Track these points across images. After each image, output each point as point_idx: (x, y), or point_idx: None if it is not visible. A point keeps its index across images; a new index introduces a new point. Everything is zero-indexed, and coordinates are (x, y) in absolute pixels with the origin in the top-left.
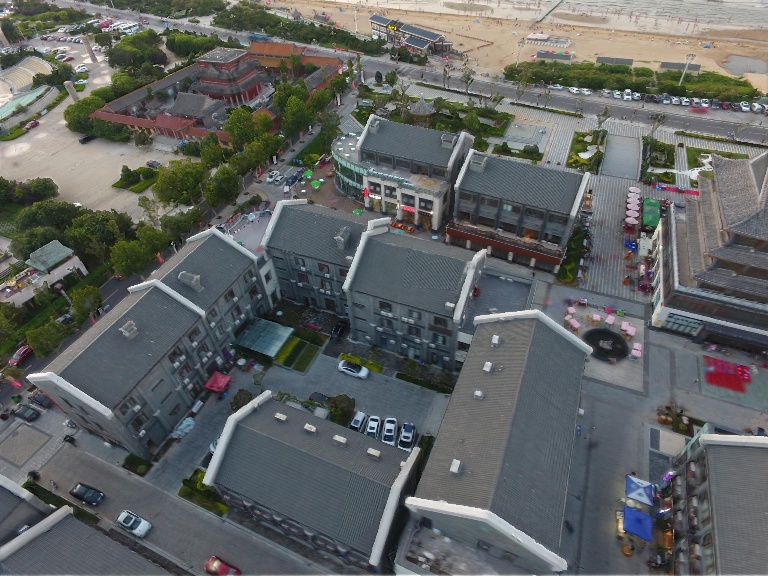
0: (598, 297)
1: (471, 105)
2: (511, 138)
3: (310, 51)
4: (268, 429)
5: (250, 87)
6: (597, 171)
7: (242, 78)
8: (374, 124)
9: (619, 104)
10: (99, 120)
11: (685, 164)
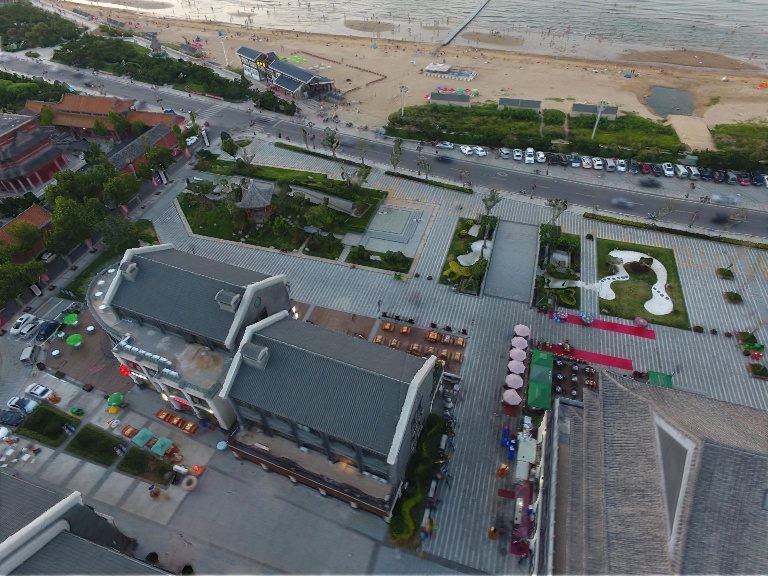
0: (448, 574)
1: (328, 184)
2: (375, 234)
3: (159, 96)
4: None
5: (41, 165)
6: (478, 290)
7: (26, 155)
8: (125, 270)
9: (519, 169)
10: None
11: (594, 270)
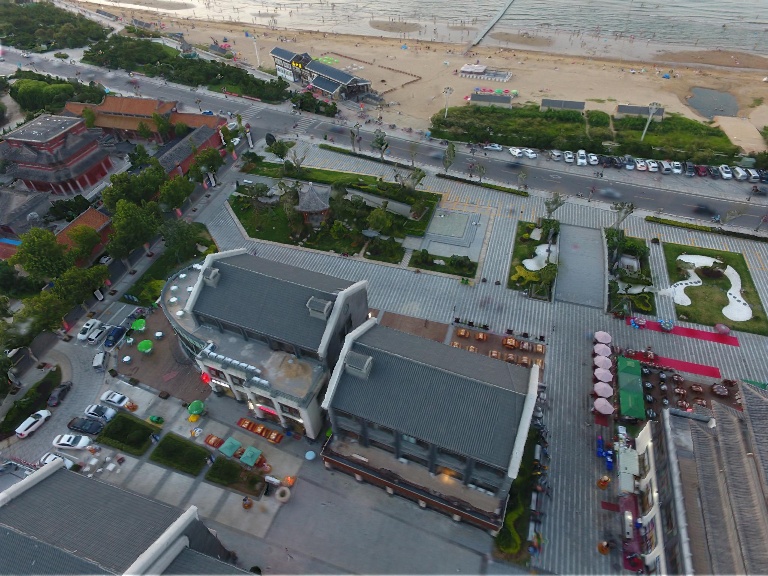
0: None
1: (383, 186)
2: (435, 237)
3: None
4: None
5: (89, 168)
6: (550, 295)
7: (75, 157)
8: (208, 276)
9: (572, 171)
10: None
11: (664, 275)
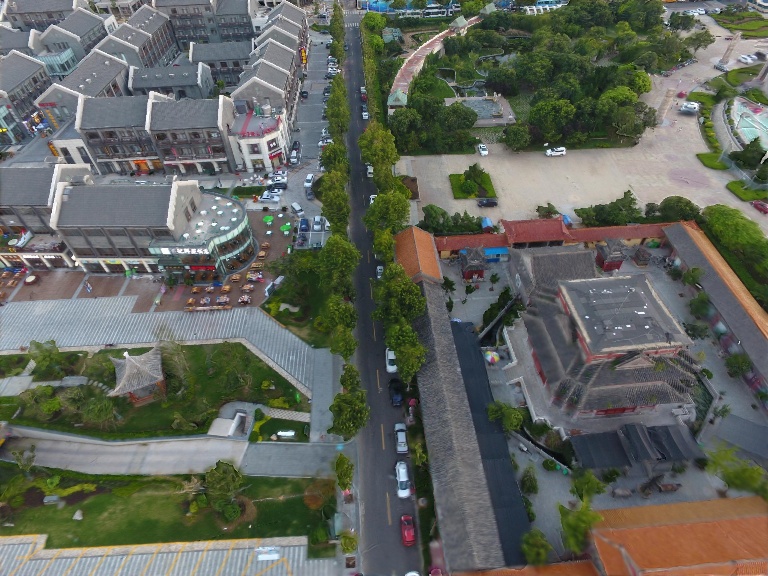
0: None
1: (27, 465)
2: None
3: None
4: (187, 69)
5: None
6: None
7: None
8: None
9: None
10: (627, 198)
11: None
